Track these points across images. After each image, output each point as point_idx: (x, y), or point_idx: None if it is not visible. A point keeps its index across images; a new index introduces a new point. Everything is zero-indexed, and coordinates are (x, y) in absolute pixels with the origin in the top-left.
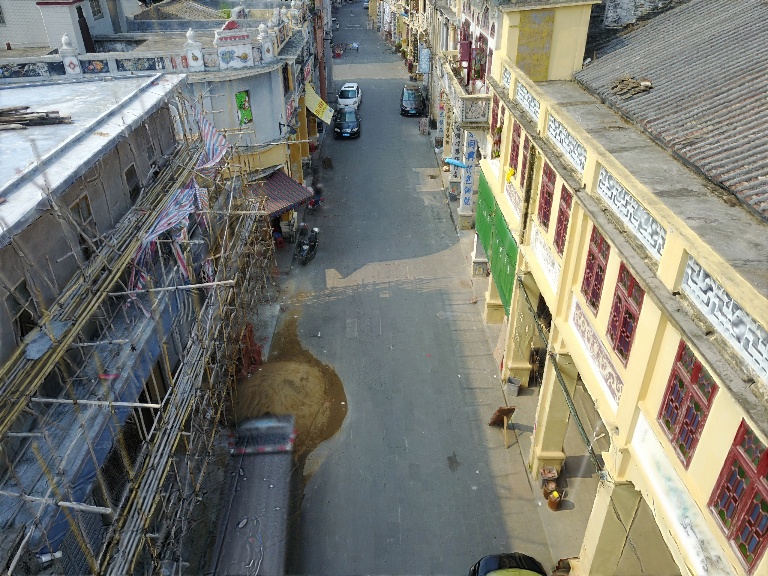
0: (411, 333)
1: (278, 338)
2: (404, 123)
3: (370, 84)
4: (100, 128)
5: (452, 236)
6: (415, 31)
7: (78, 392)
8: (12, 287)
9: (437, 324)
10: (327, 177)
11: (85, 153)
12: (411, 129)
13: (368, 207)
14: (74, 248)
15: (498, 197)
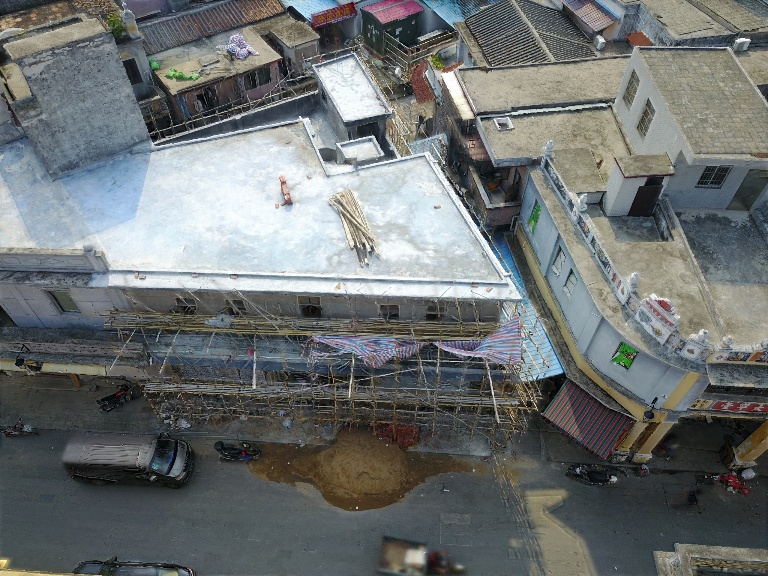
0: (446, 573)
1: (442, 458)
2: None
3: None
4: (352, 282)
5: None
6: None
7: (243, 344)
8: (233, 299)
9: None
10: None
11: (303, 288)
12: None
13: None
14: (293, 308)
15: None
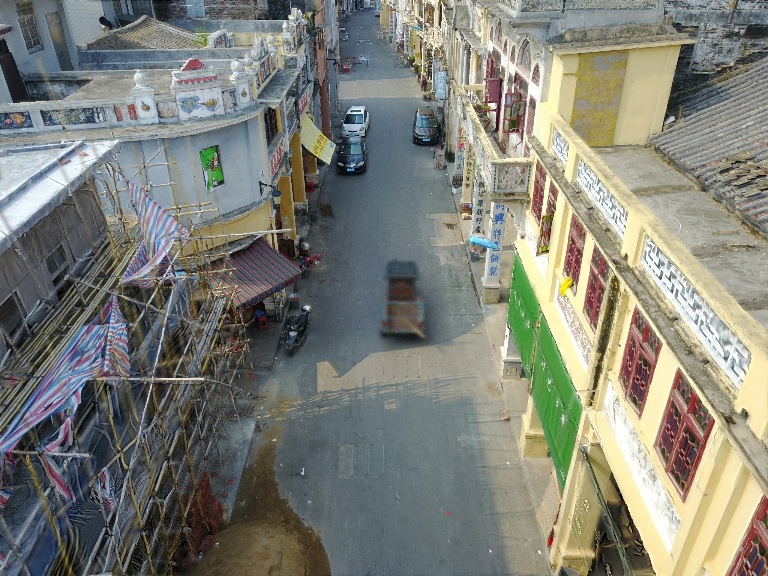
0: (424, 471)
1: (249, 477)
2: (417, 153)
3: (380, 104)
4: None
5: (475, 312)
6: (429, 46)
7: None
8: None
9: (458, 456)
10: (326, 225)
11: None
12: (425, 161)
13: (373, 268)
14: None
15: (546, 309)
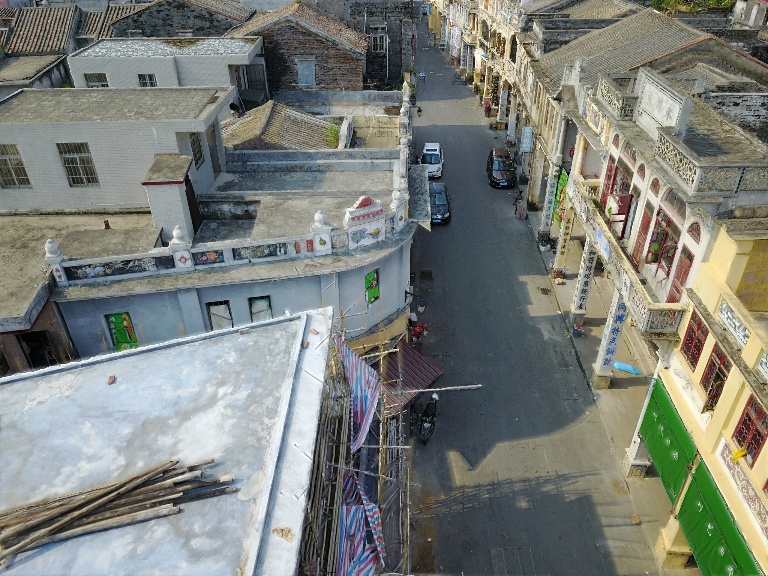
0: None
1: None
2: (495, 199)
3: (447, 134)
4: (275, 508)
5: (586, 397)
6: (496, 73)
7: None
8: None
9: (600, 563)
10: (425, 288)
11: None
12: (505, 209)
13: (480, 342)
14: None
15: (710, 462)
